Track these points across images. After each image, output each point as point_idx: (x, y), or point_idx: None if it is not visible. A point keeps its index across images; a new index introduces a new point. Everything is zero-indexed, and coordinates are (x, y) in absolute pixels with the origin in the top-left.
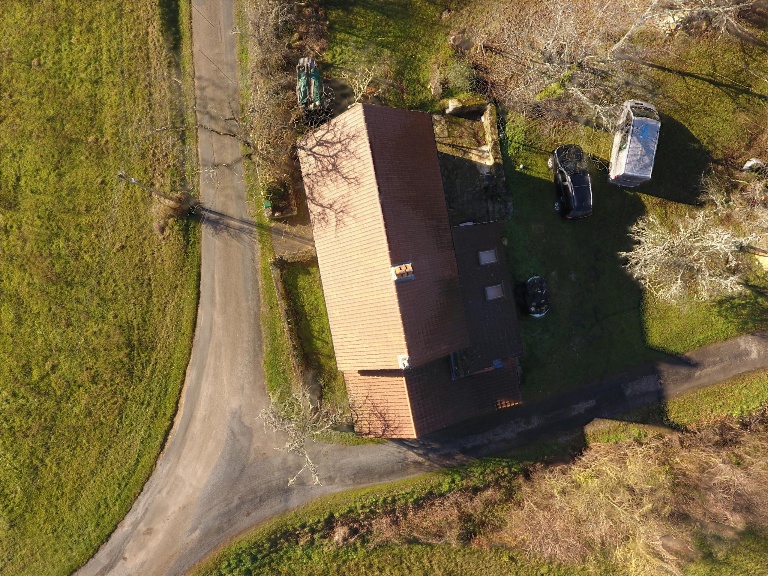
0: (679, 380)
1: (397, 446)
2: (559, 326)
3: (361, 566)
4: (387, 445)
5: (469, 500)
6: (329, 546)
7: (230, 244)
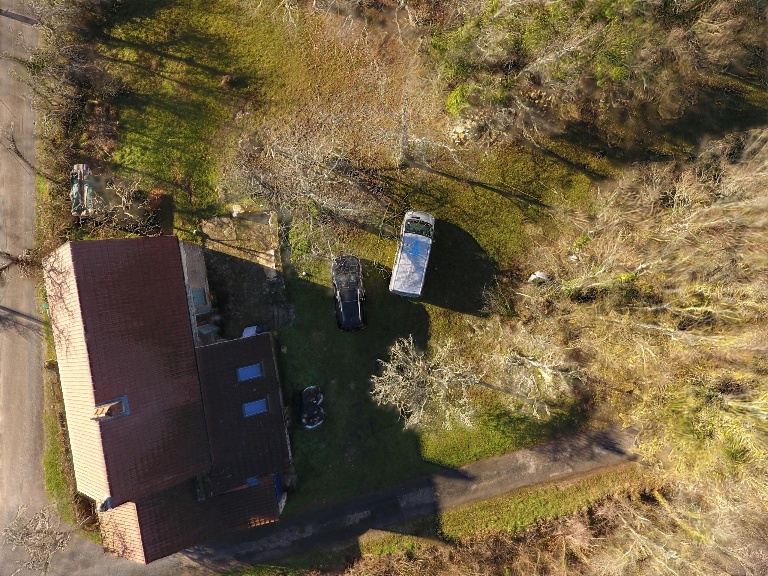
0: (455, 493)
1: None
2: (336, 436)
3: None
4: None
5: None
6: None
7: (17, 341)
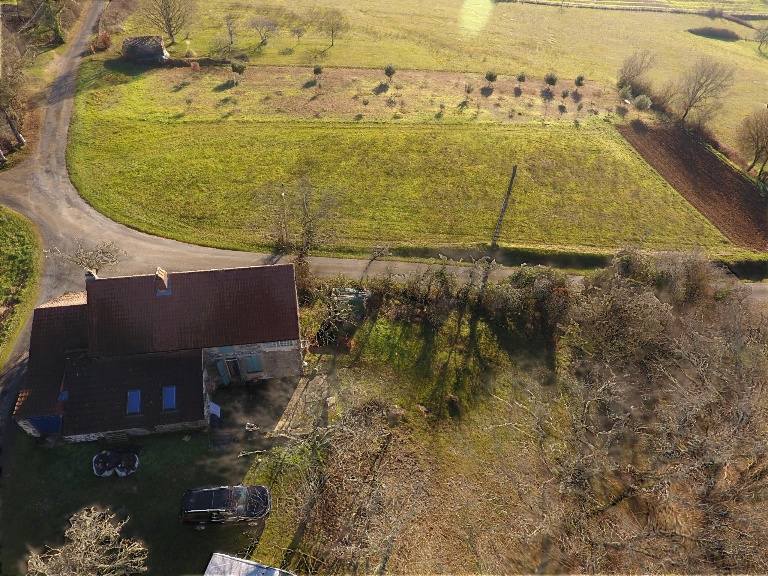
0: None
1: None
2: (73, 489)
3: None
4: None
5: None
6: None
7: None
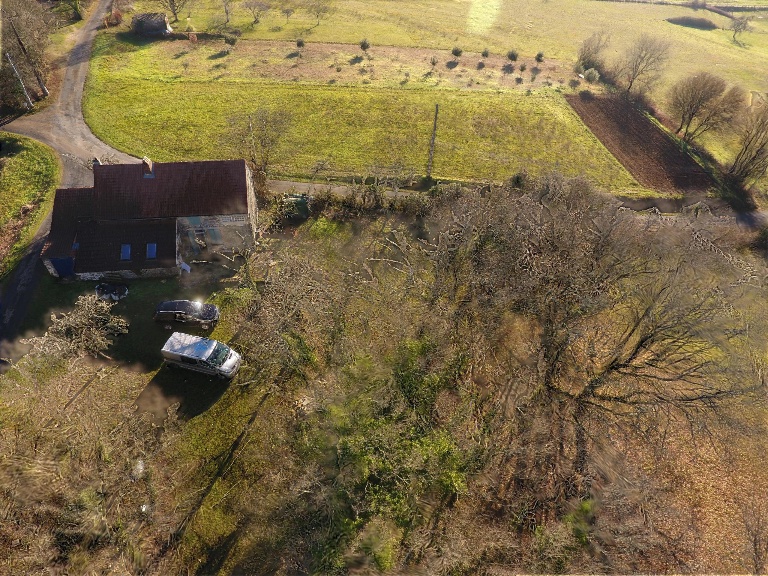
0: None
1: None
2: None
3: (1, 216)
4: None
5: None
6: None
7: None
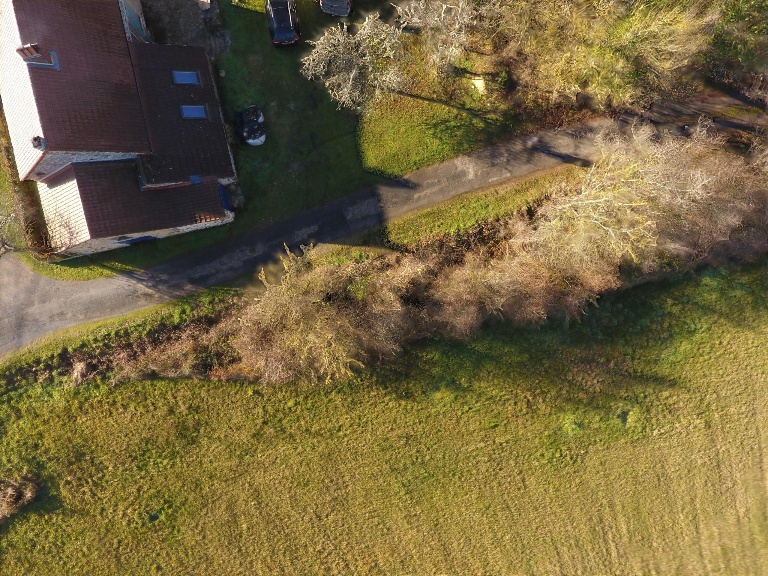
0: (399, 203)
1: (126, 279)
2: (279, 154)
3: (104, 403)
4: (117, 279)
5: (205, 333)
6: (69, 383)
7: None
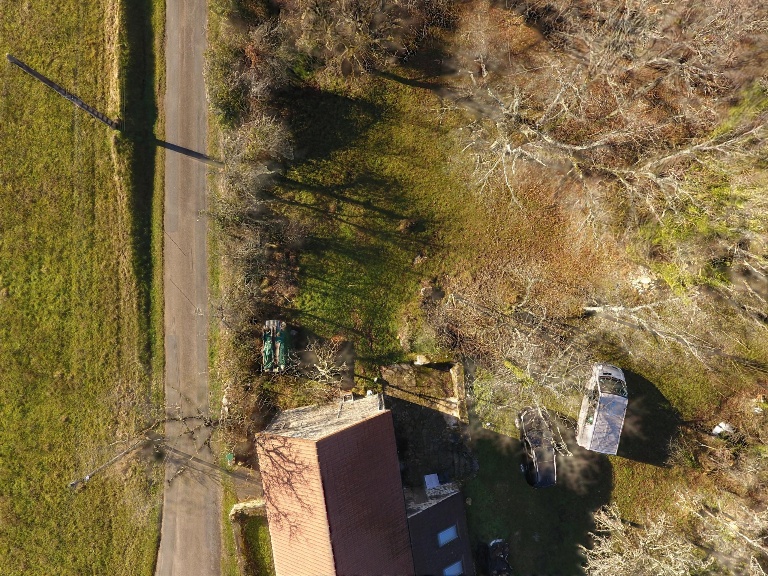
0: None
1: None
2: None
3: None
4: None
5: None
6: None
7: (193, 486)
